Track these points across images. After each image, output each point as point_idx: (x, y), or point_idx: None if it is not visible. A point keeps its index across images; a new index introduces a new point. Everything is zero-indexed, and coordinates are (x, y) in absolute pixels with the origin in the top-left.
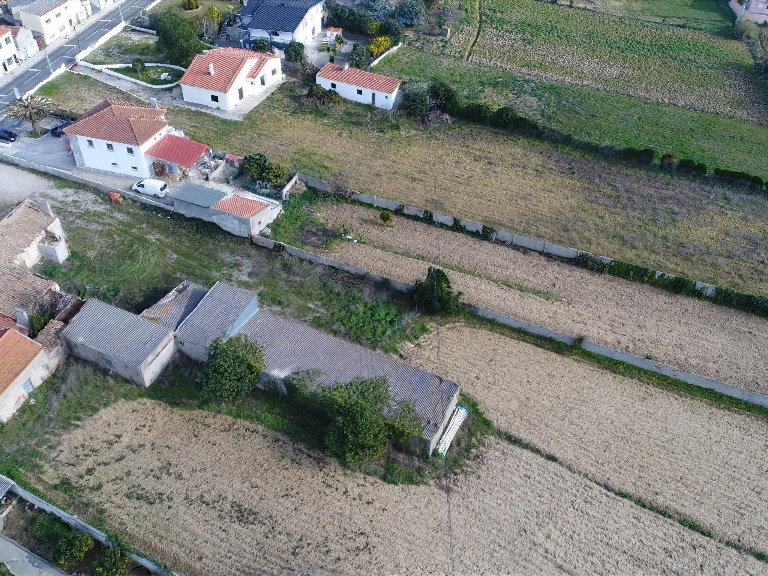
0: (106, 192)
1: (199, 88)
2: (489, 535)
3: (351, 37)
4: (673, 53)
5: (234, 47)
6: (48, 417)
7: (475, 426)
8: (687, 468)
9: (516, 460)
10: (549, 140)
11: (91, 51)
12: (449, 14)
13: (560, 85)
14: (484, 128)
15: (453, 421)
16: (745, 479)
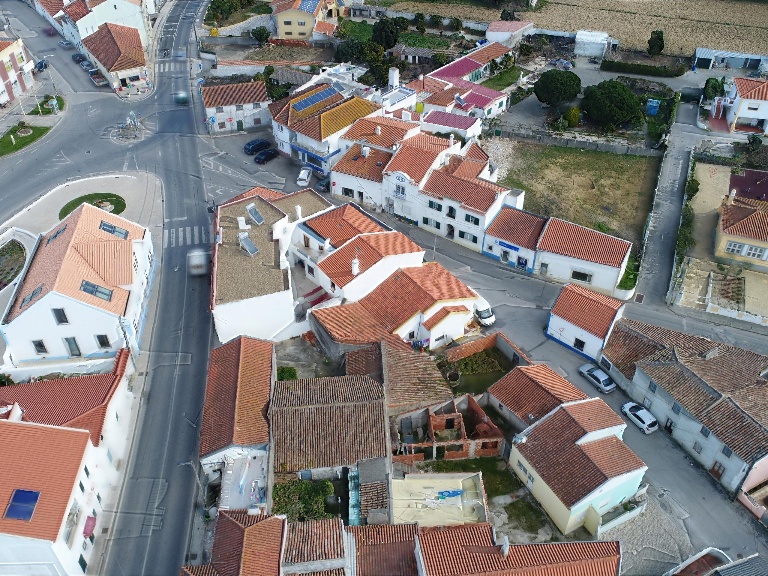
0: None
1: None
2: None
3: None
4: None
5: None
6: (377, 5)
7: (542, 2)
8: (625, 4)
9: (562, 6)
10: None
11: None
12: None
13: None
14: None
15: (534, 0)
16: (646, 4)
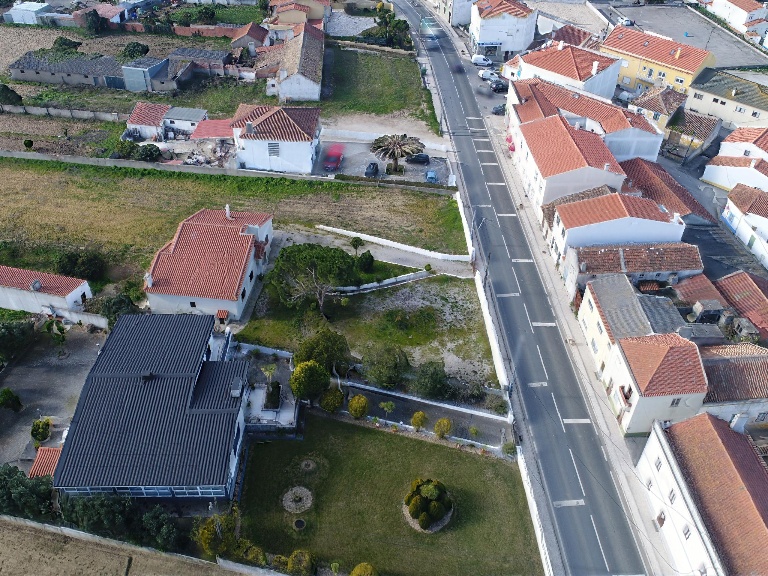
0: None
1: None
2: (16, 53)
3: None
4: None
5: (246, 340)
6: None
7: (7, 76)
8: None
9: None
10: None
11: None
12: None
13: None
14: None
15: None
16: None
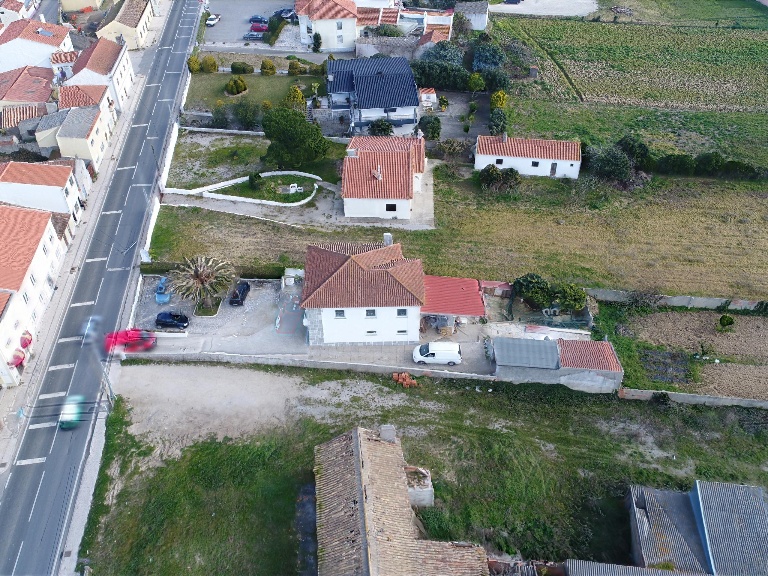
0: (387, 375)
1: (371, 199)
2: None
3: (442, 95)
4: (762, 58)
5: (343, 134)
6: None
7: None
8: None
9: None
10: (765, 181)
11: (168, 172)
12: (516, 51)
13: (701, 113)
14: (688, 180)
15: None
16: None
